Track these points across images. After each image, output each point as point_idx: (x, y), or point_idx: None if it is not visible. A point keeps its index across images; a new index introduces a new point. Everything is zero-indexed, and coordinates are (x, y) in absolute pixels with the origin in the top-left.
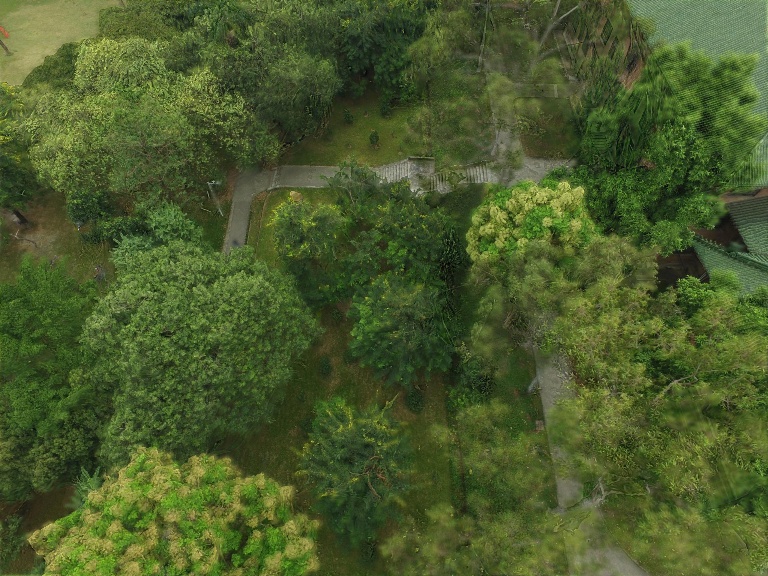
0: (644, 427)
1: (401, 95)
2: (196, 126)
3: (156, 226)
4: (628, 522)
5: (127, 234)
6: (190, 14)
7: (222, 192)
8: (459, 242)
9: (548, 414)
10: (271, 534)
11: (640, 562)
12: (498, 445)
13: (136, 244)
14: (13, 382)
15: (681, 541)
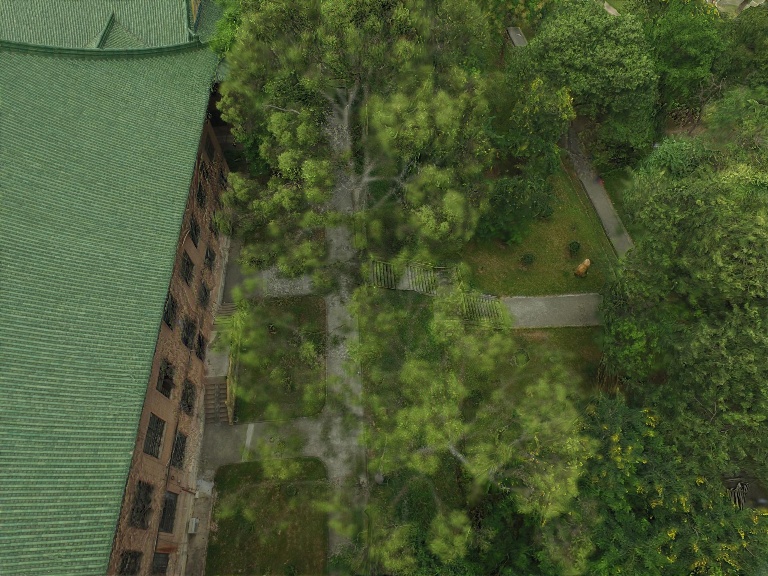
0: None
1: None
2: None
3: None
4: None
5: None
6: None
7: None
8: (404, 183)
9: (344, 97)
10: None
11: None
12: (375, 91)
13: None
14: None
15: None
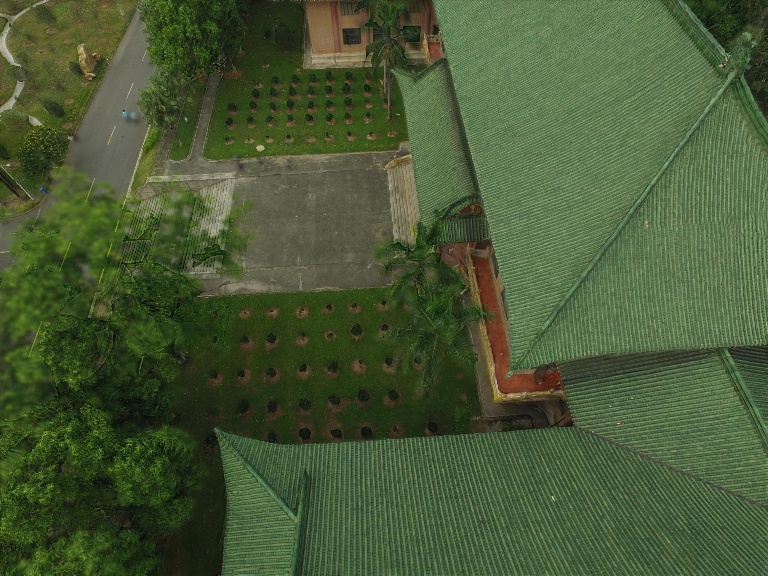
0: None
1: None
2: None
3: None
4: None
5: None
6: None
7: None
8: None
9: None
10: None
11: None
12: None
13: None
14: None
15: None
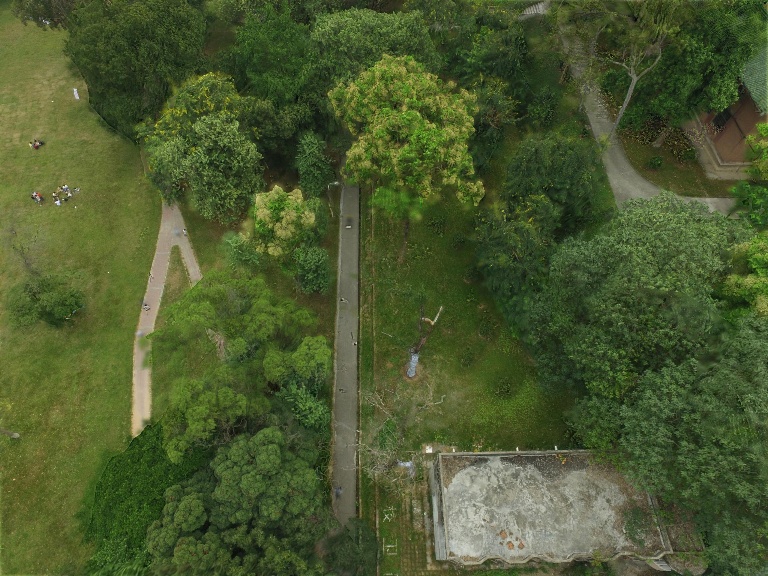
0: (656, 127)
1: None
2: None
3: None
4: (647, 165)
5: None
6: None
7: None
8: None
9: (593, 123)
10: (456, 95)
11: (655, 182)
12: None
13: None
14: (267, 73)
15: (680, 173)
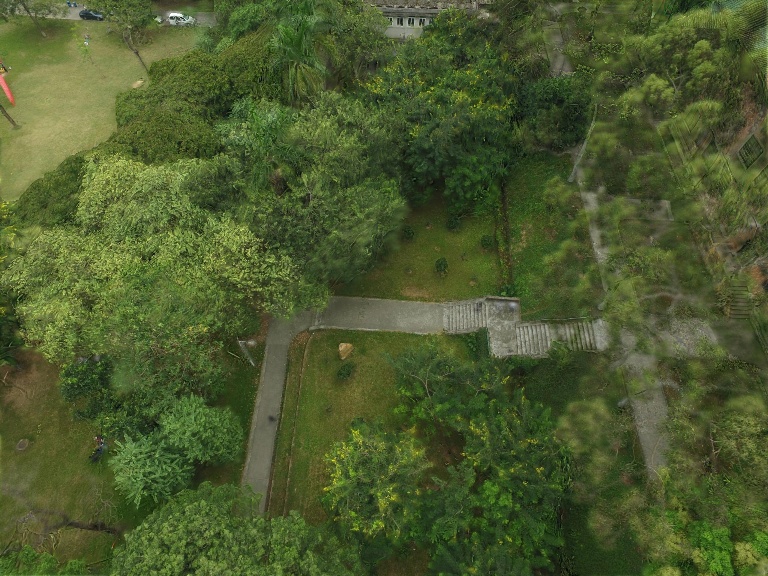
0: None
1: (474, 207)
2: (227, 291)
3: (170, 432)
4: None
5: (133, 433)
6: (222, 96)
7: (254, 330)
8: (571, 457)
9: None
10: None
11: None
12: None
13: (144, 453)
14: None
15: None
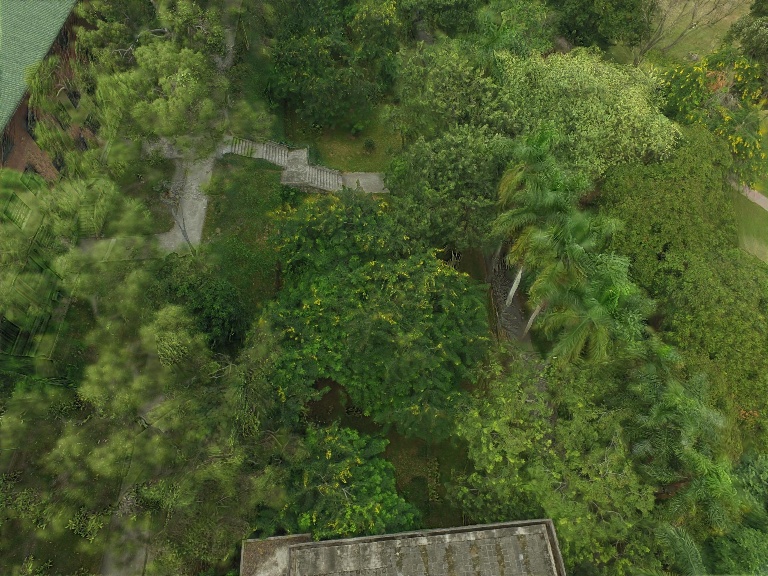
0: None
1: None
2: None
3: None
4: None
5: None
6: None
7: None
8: None
9: None
10: None
11: None
12: None
13: None
14: None
15: None
